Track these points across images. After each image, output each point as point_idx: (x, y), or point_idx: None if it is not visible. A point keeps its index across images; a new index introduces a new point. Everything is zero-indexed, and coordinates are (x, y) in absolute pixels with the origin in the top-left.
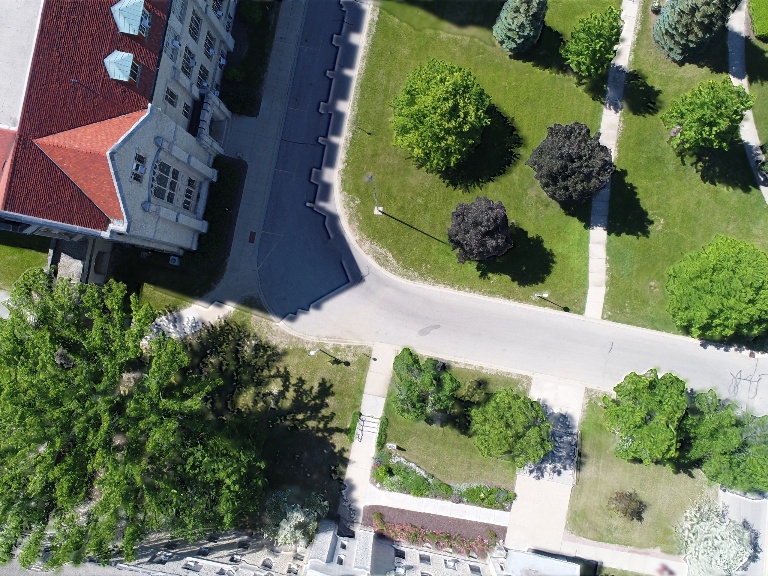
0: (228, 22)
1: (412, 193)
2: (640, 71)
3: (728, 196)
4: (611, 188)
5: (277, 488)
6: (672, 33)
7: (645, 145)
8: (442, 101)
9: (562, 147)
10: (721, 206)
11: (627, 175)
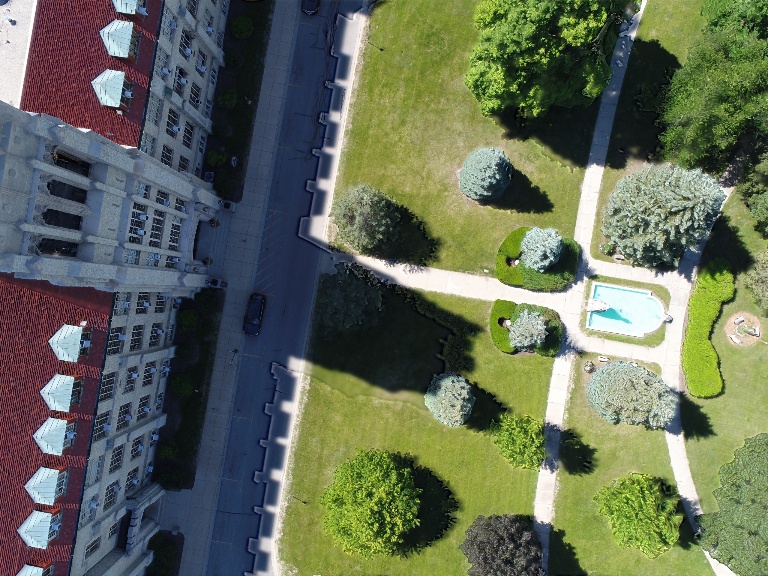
0: (158, 402)
1: (350, 561)
2: (575, 430)
3: (668, 553)
4: (549, 548)
5: None
6: (603, 408)
7: (582, 505)
8: (366, 527)
9: (488, 573)
10: (661, 563)
11: (565, 535)
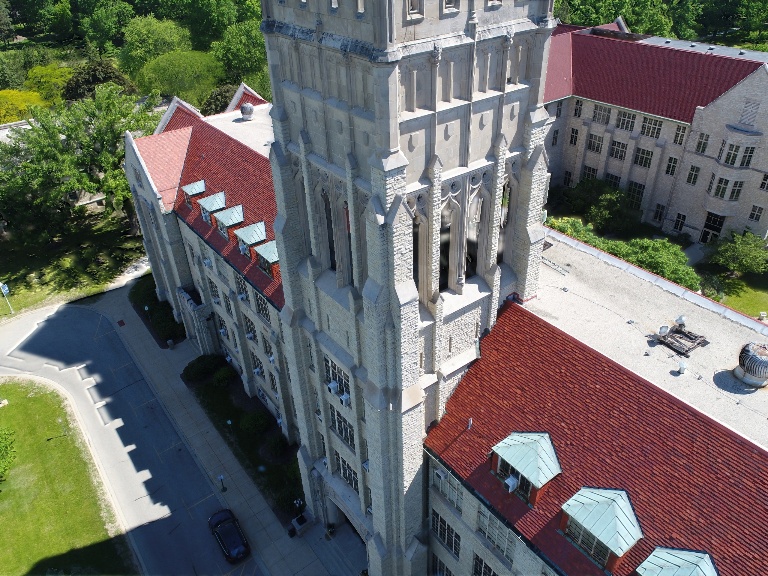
0: None
1: None
2: None
3: None
4: None
5: (0, 251)
6: None
7: None
8: None
9: None
10: None
11: None
